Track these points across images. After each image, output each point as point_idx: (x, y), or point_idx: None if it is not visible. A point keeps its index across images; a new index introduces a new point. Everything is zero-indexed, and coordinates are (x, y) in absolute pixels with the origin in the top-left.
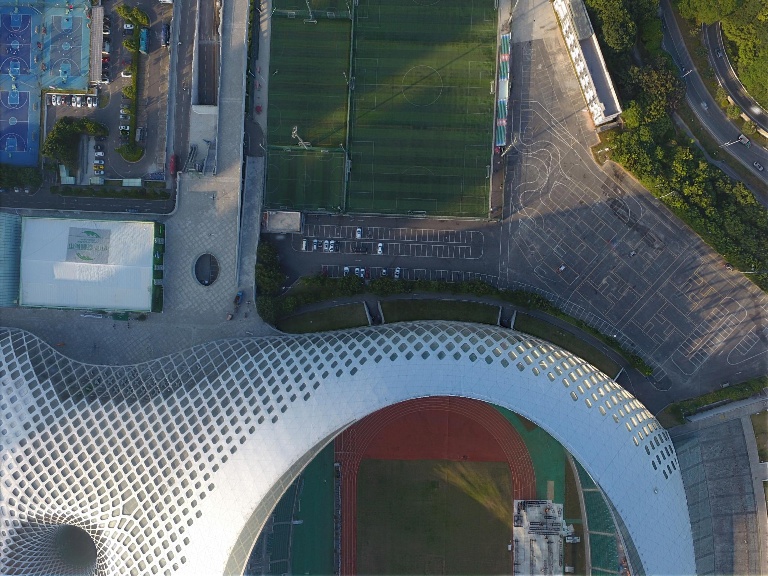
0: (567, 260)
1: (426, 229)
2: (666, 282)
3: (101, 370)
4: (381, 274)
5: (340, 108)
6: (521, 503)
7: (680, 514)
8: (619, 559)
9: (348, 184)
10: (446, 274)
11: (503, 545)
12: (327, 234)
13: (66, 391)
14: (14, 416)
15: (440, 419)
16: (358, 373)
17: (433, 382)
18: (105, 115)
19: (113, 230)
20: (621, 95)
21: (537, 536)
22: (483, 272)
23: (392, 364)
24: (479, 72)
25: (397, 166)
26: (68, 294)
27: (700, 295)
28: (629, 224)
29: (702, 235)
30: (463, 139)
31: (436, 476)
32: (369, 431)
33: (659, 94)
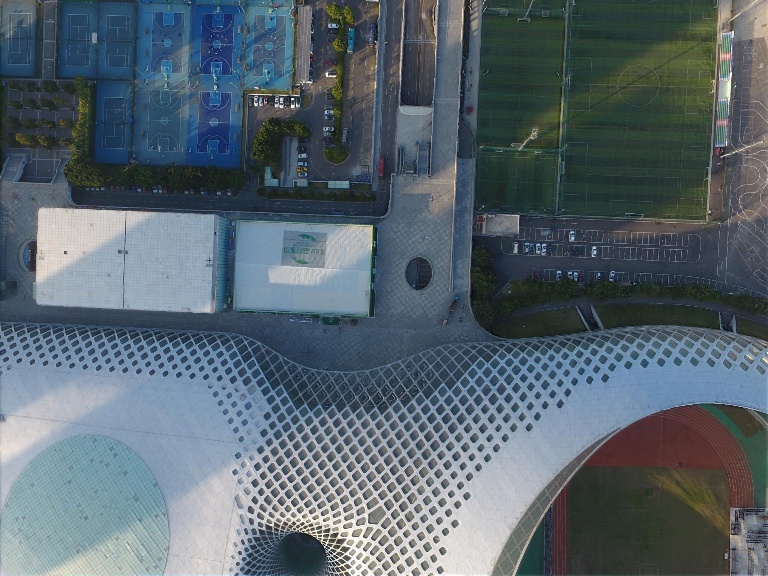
0: None
1: (641, 232)
2: None
3: (332, 376)
4: (595, 278)
5: (553, 108)
6: (739, 511)
7: None
8: None
9: (560, 186)
10: (662, 278)
11: (719, 554)
12: (538, 237)
13: (300, 397)
14: (250, 423)
15: (654, 425)
16: (611, 380)
17: (694, 389)
18: (308, 116)
19: (329, 233)
20: None
21: (755, 545)
22: (701, 276)
23: (646, 371)
24: (698, 71)
25: (612, 168)
26: (282, 298)
27: None
28: None
29: None
30: (681, 140)
31: (650, 483)
32: None
33: None
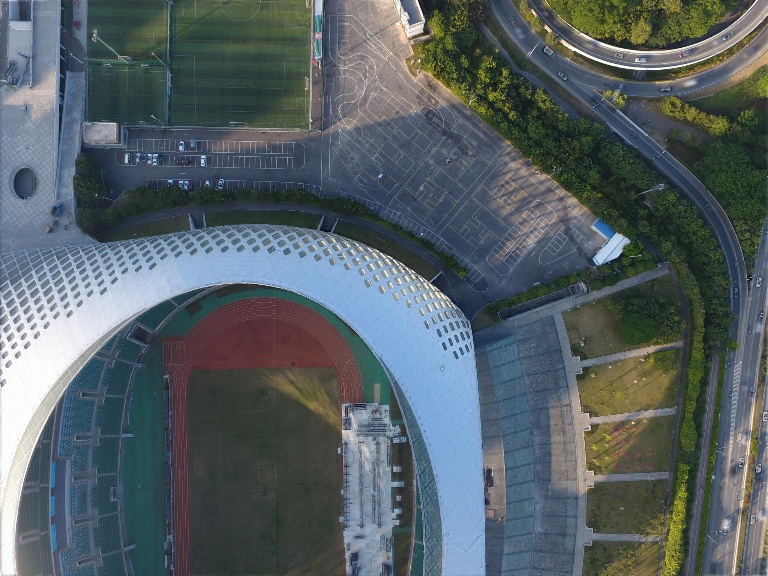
0: (385, 168)
1: (248, 141)
2: (480, 187)
3: None
4: (205, 186)
5: (160, 23)
6: (348, 406)
7: (468, 391)
8: None
9: (170, 98)
10: (269, 185)
11: (333, 449)
12: (150, 148)
13: None
14: None
15: (268, 328)
16: (156, 267)
17: (227, 271)
18: None
19: None
20: (428, 6)
21: (365, 438)
22: (305, 182)
23: (190, 258)
24: None
25: (218, 80)
26: None
27: (512, 199)
28: (443, 132)
29: (510, 140)
30: (282, 52)
31: (265, 384)
32: (198, 342)
33: (462, 4)
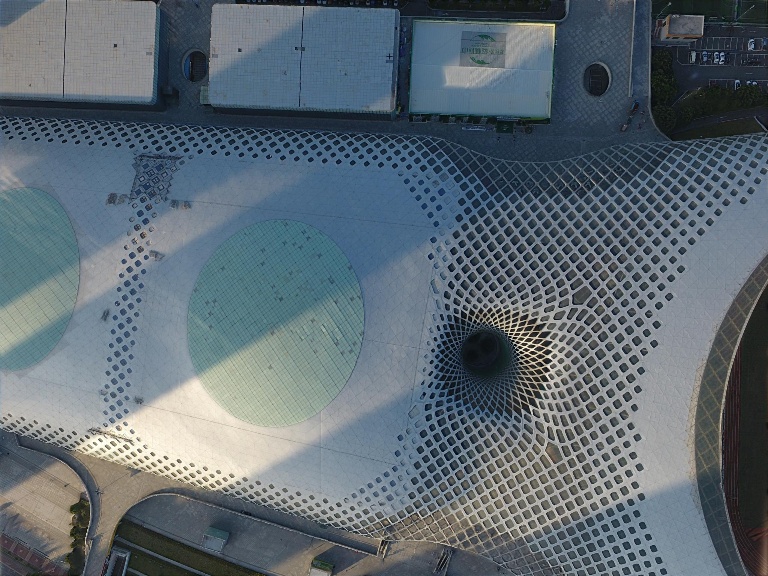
0: None
1: None
2: None
3: (524, 166)
4: None
5: None
6: None
7: None
8: None
9: None
10: None
11: None
12: (716, 46)
13: (493, 185)
14: (445, 208)
15: None
16: None
17: None
18: None
19: (509, 33)
20: None
21: None
22: None
23: None
24: None
25: None
26: (459, 101)
27: None
28: None
29: None
30: None
31: None
32: None
33: None
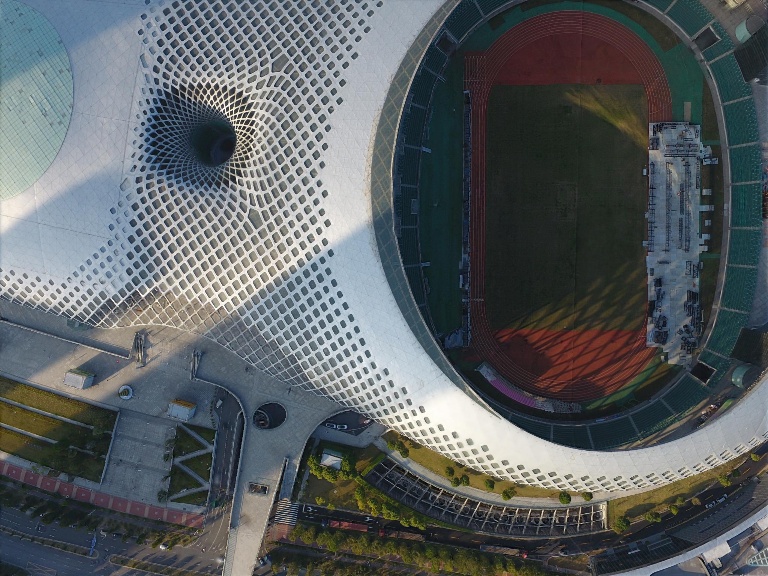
0: None
1: None
2: None
3: None
4: None
5: None
6: (657, 125)
7: None
8: (763, 168)
9: None
10: None
11: (638, 170)
12: None
13: None
14: None
15: (573, 43)
16: None
17: None
18: None
19: None
20: None
21: (673, 159)
22: None
23: None
24: None
25: None
26: None
27: None
28: None
29: None
30: None
31: (569, 101)
32: (500, 57)
33: None
